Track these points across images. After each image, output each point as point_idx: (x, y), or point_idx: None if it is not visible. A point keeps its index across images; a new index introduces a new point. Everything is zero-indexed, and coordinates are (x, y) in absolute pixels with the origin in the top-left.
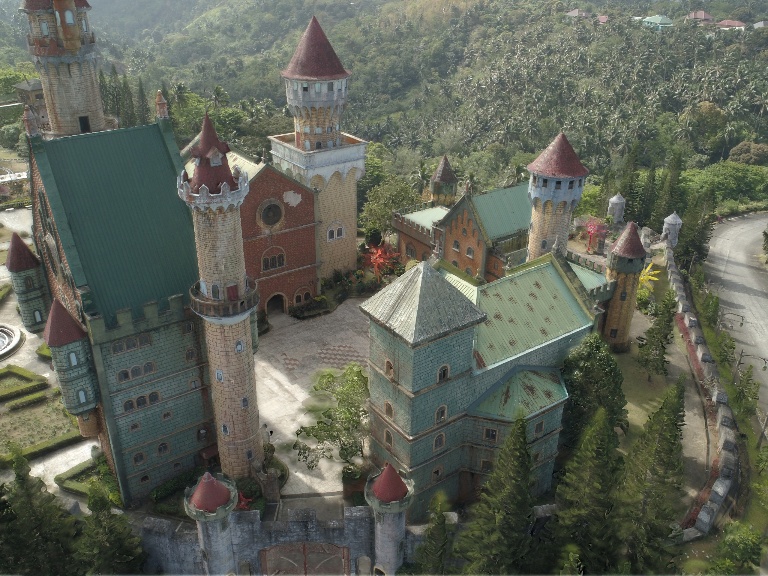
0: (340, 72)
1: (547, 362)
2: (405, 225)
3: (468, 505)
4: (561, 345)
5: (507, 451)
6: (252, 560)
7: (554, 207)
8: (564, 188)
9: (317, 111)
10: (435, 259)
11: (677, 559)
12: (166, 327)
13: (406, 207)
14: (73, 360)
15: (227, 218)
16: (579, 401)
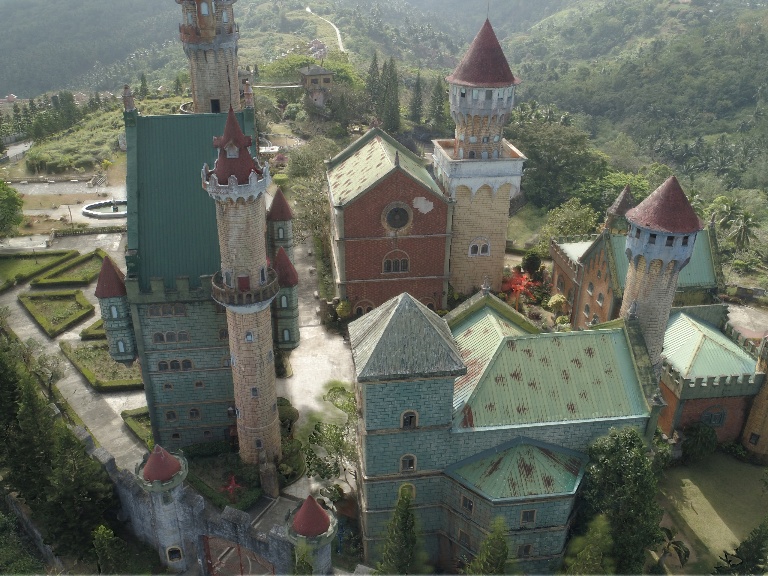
0: (504, 80)
1: (572, 444)
2: (558, 255)
3: (447, 573)
4: (595, 429)
5: (389, 524)
6: (194, 542)
7: (646, 264)
8: (659, 243)
9: (472, 119)
10: (481, 295)
11: None
12: (201, 303)
13: None
14: (114, 313)
15: (239, 210)
16: (591, 502)
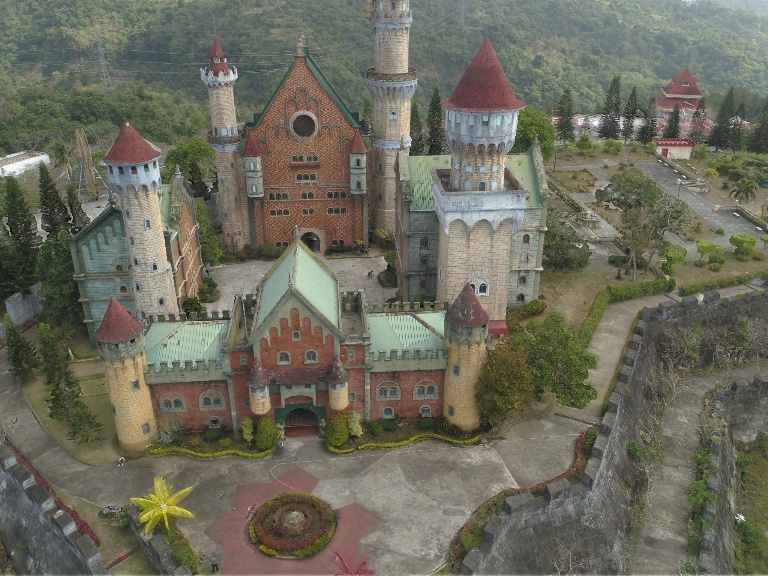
0: (456, 102)
1: None
2: None
3: None
4: None
5: None
6: None
7: None
8: None
9: None
10: None
11: None
12: None
13: None
14: None
15: None
16: None
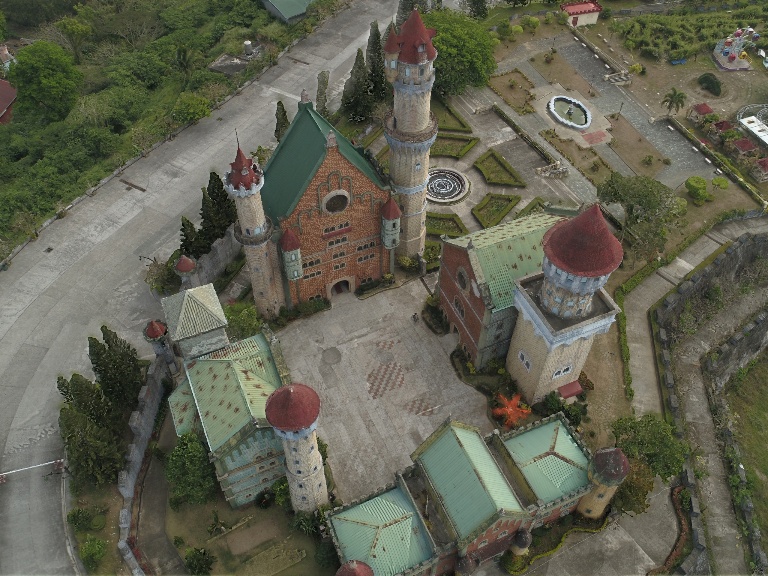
0: (568, 263)
1: None
2: None
3: None
4: None
5: None
6: None
7: None
8: None
9: None
10: None
11: (114, 519)
12: None
13: None
14: None
15: None
16: None
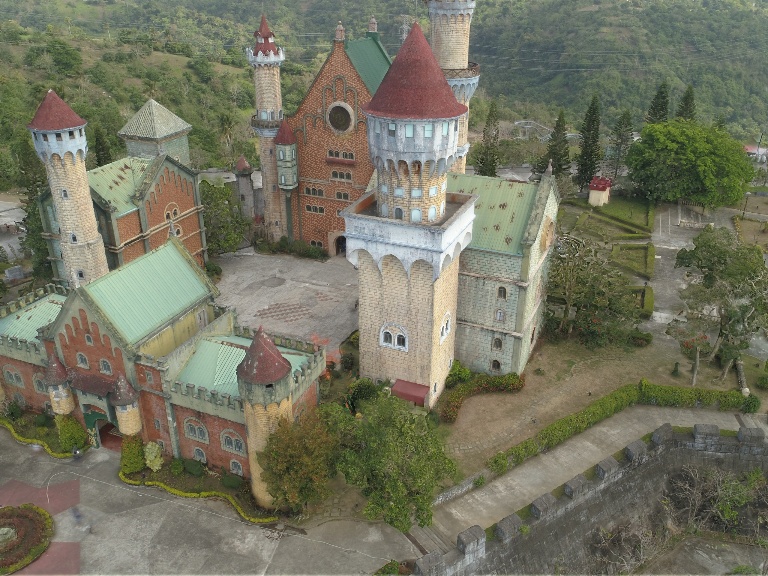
0: None
1: None
2: None
3: None
4: None
5: None
6: None
7: None
8: None
9: None
10: None
11: None
12: None
13: (312, 358)
14: None
15: None
16: None
